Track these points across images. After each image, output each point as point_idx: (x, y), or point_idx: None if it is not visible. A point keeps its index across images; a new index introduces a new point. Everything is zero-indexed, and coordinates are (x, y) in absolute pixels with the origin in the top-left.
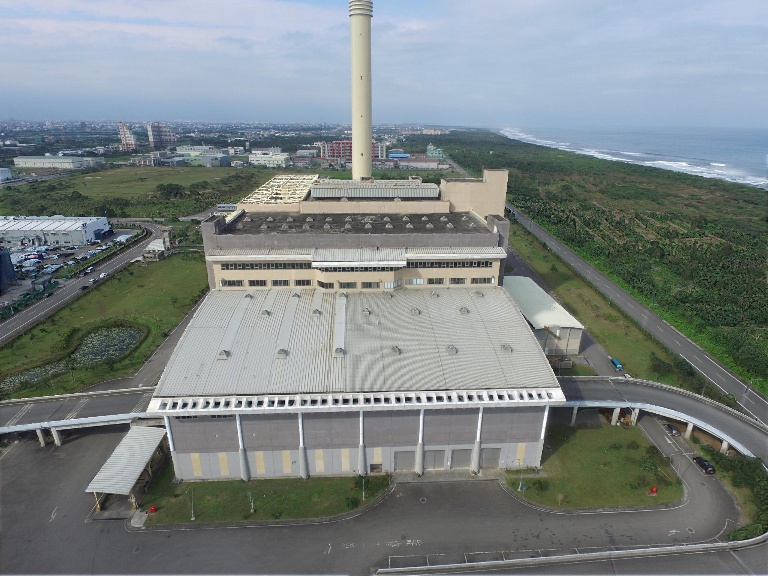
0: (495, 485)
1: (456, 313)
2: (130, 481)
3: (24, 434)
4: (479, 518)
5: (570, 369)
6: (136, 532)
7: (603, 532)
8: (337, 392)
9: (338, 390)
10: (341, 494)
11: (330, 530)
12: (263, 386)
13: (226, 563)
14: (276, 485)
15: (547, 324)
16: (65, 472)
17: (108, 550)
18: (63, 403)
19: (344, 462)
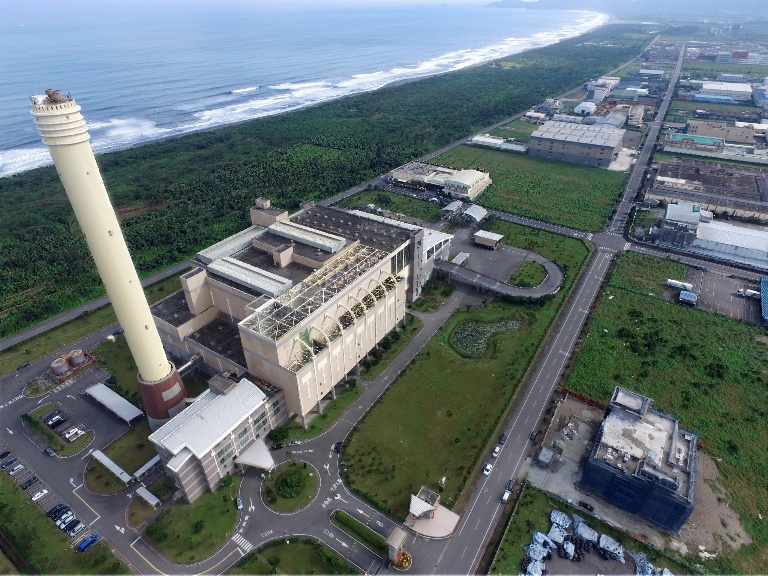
0: None
1: None
2: None
3: (496, 293)
4: None
5: None
6: None
7: None
8: None
9: None
10: None
11: None
12: None
13: None
14: None
15: None
16: None
17: None
18: (483, 282)
19: None
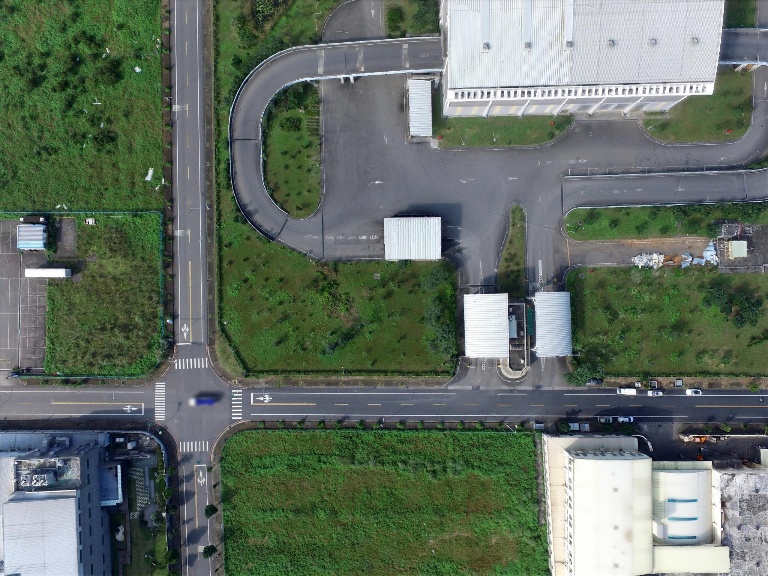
0: (635, 124)
1: None
2: (429, 127)
3: None
4: (620, 147)
5: None
6: (436, 152)
7: (685, 158)
8: (565, 85)
9: (566, 84)
10: (543, 129)
11: (539, 153)
12: (517, 80)
13: (489, 170)
14: (504, 121)
15: None
16: (372, 107)
17: (427, 162)
18: (345, 51)
19: (547, 109)
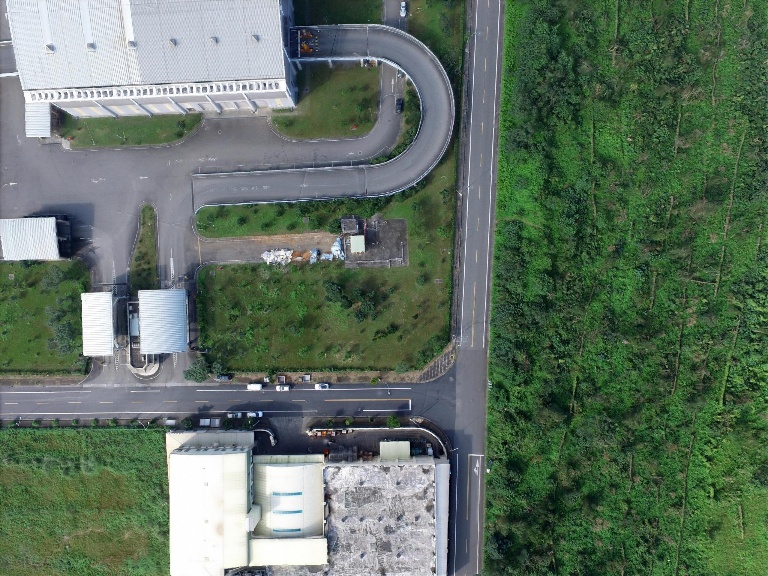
0: (264, 121)
1: None
2: (47, 128)
3: None
4: (249, 145)
5: None
6: (68, 152)
7: (313, 154)
8: (138, 85)
9: (138, 83)
10: (172, 128)
11: (169, 152)
12: (88, 80)
13: (120, 170)
14: (134, 121)
15: None
16: (5, 109)
17: (59, 162)
18: None
19: (169, 108)
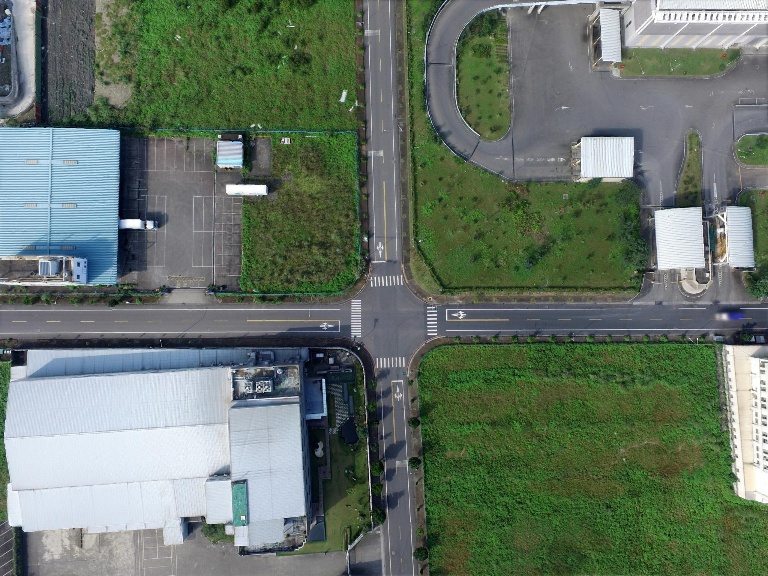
0: None
1: None
2: (619, 53)
3: None
4: None
5: None
6: (618, 80)
7: None
8: (763, 10)
9: (764, 8)
10: (716, 61)
11: (712, 83)
12: (721, 3)
13: (667, 98)
14: (680, 53)
15: None
16: (557, 37)
17: (610, 89)
18: None
19: (723, 41)
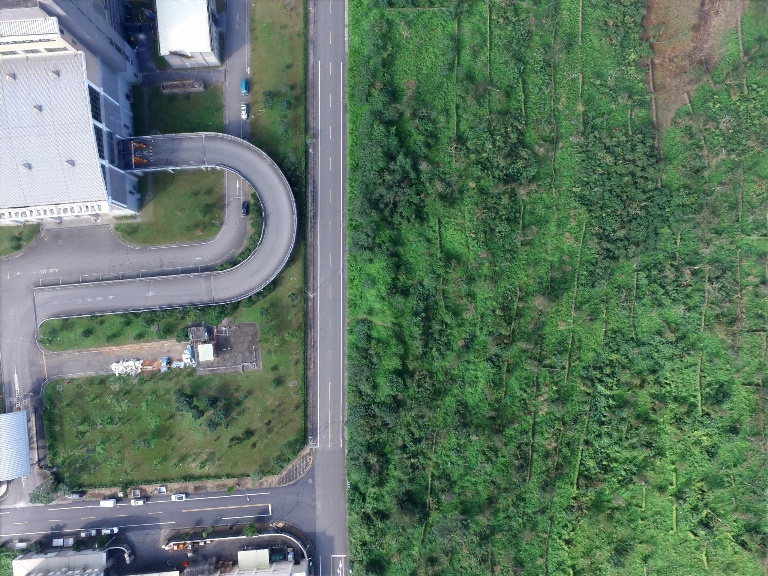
0: (106, 229)
1: (31, 112)
2: None
3: None
4: (92, 254)
5: (202, 93)
6: None
7: (159, 261)
8: None
9: None
10: (10, 240)
11: (7, 265)
12: None
13: None
14: None
15: (172, 49)
16: None
17: None
18: None
19: None
